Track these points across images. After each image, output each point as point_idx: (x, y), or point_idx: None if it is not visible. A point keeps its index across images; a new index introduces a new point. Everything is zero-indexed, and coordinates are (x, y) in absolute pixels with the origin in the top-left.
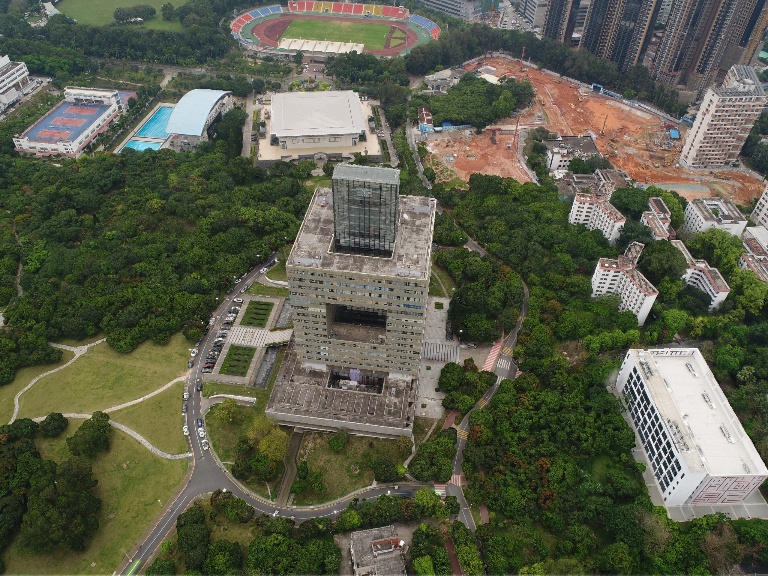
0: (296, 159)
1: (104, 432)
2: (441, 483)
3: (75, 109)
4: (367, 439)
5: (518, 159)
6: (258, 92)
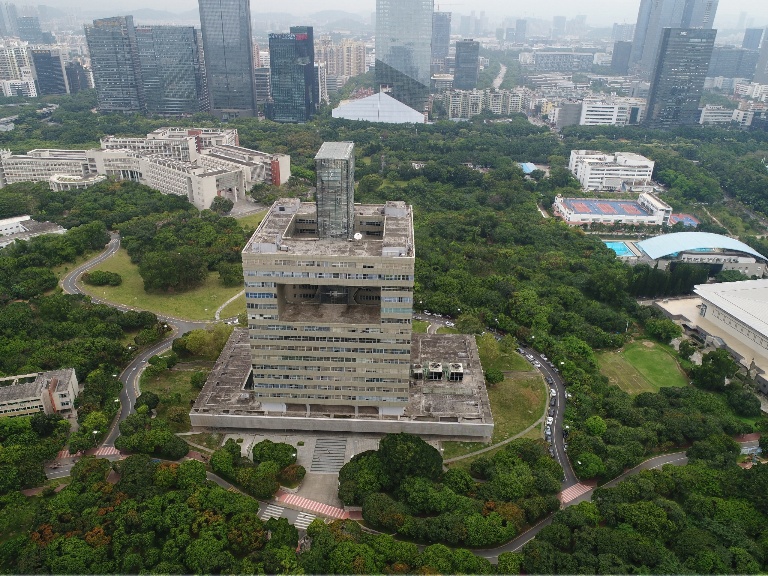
0: (690, 327)
1: (234, 275)
2: None
3: (629, 207)
4: None
5: None
6: None
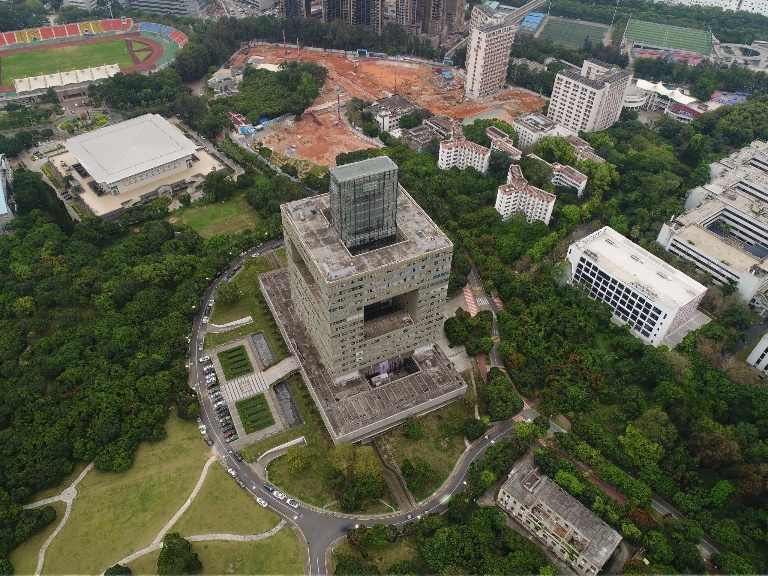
0: (139, 201)
1: (189, 551)
2: (516, 414)
3: None
4: (431, 415)
5: (351, 132)
6: (28, 146)
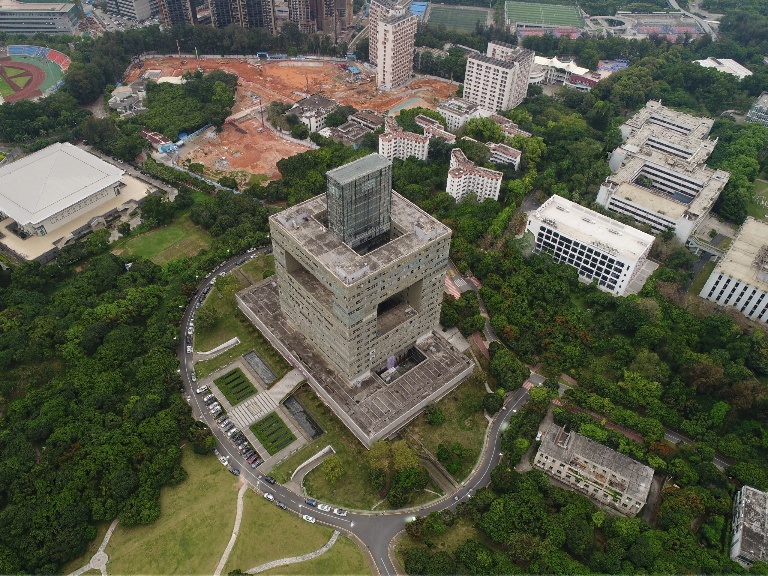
0: (71, 238)
1: None
2: (524, 381)
3: None
4: (446, 398)
5: (279, 137)
6: None
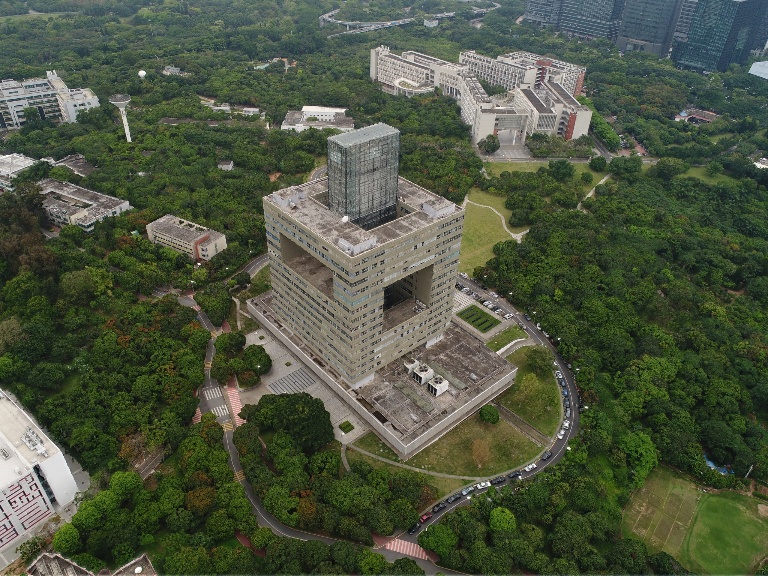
0: None
1: None
2: None
3: None
4: None
5: None
6: None
